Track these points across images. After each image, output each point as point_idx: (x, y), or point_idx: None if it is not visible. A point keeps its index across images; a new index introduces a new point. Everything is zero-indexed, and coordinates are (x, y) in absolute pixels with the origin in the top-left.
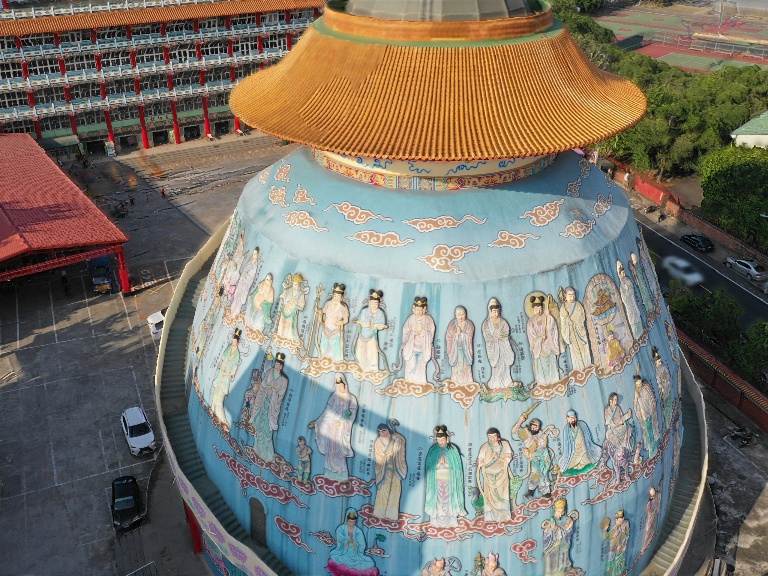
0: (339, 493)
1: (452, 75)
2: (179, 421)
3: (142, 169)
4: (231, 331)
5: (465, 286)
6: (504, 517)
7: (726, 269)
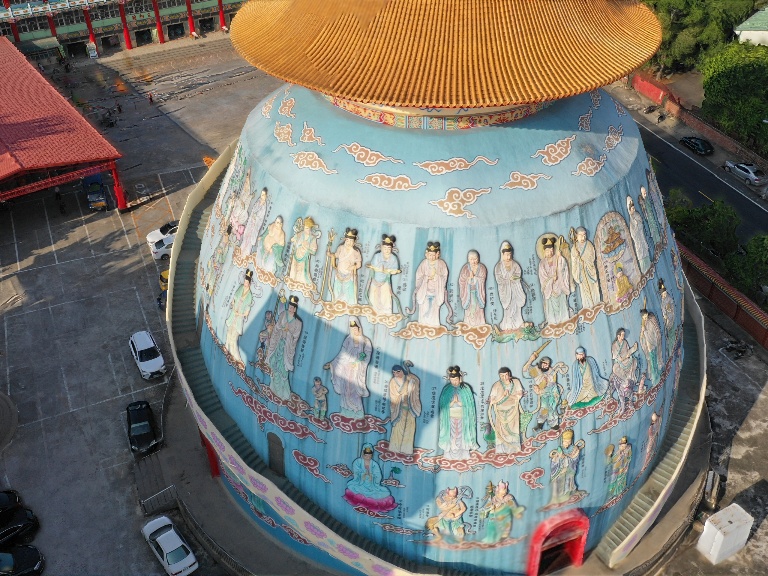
0: (355, 430)
1: (465, 13)
2: (192, 356)
3: (127, 72)
4: (242, 272)
5: (478, 230)
6: (514, 449)
7: (725, 173)
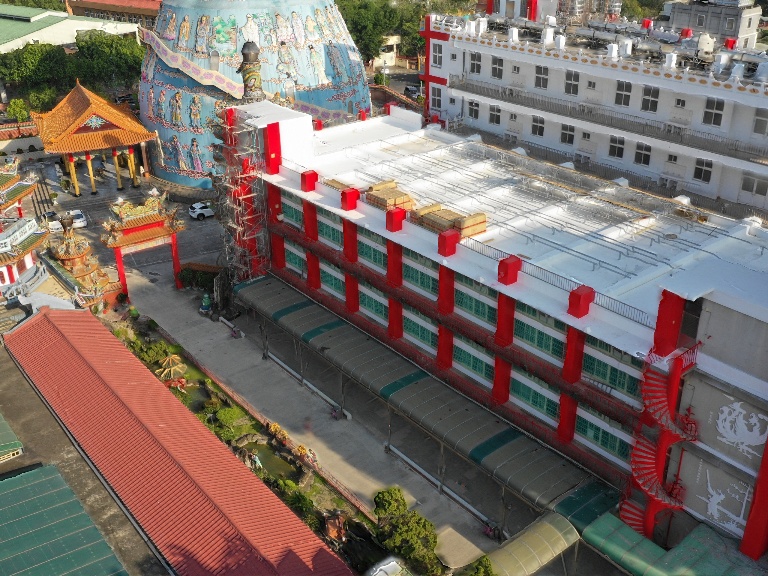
0: None
1: None
2: None
3: None
4: (307, 49)
5: None
6: None
7: None
